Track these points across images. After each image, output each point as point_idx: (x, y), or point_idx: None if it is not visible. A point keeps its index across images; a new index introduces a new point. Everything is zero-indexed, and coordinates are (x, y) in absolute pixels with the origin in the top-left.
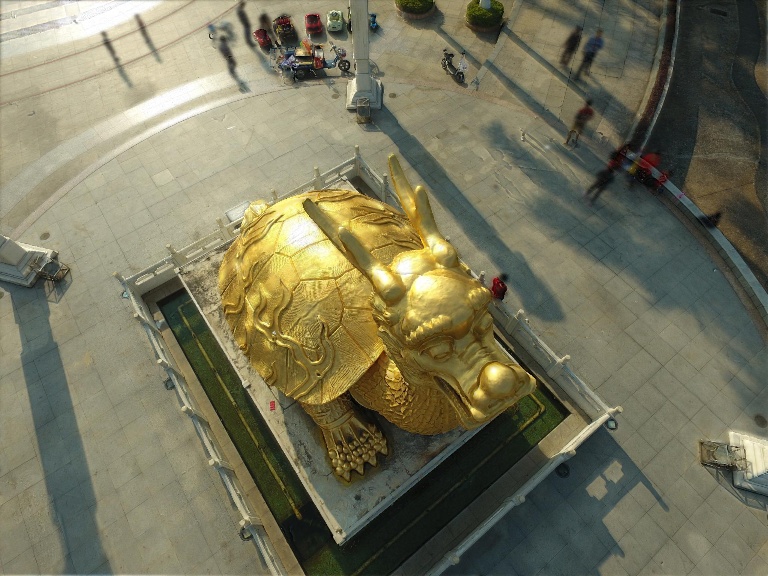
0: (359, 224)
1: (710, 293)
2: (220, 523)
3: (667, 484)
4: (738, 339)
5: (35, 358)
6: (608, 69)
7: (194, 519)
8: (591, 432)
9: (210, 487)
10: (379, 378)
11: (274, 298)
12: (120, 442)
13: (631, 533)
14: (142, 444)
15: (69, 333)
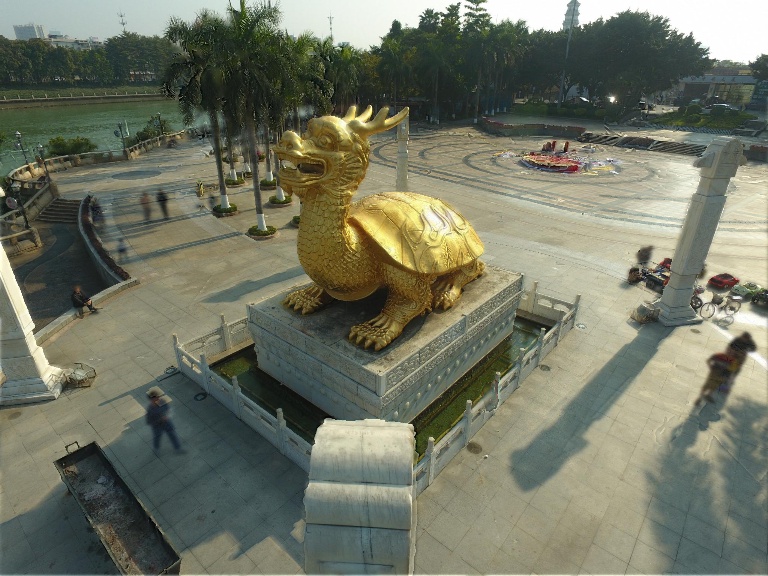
0: (427, 204)
1: None
2: None
3: None
4: None
5: None
6: None
7: None
8: None
9: None
10: None
11: None
12: None
13: (255, 569)
14: None
15: None
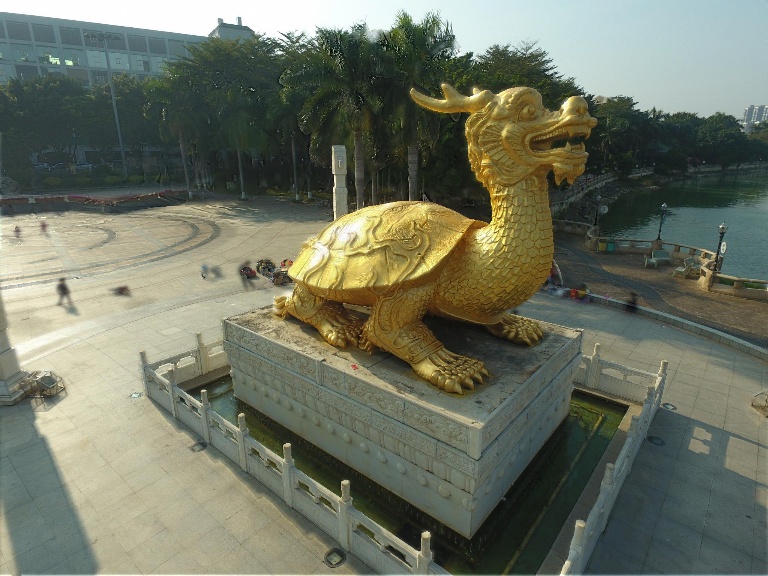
0: None
1: (671, 336)
2: (293, 556)
3: (754, 434)
4: (715, 352)
5: (10, 453)
6: None
7: (253, 559)
8: (656, 387)
9: (269, 524)
10: (471, 248)
11: (364, 228)
12: (132, 505)
13: (760, 472)
14: (165, 502)
15: (61, 429)
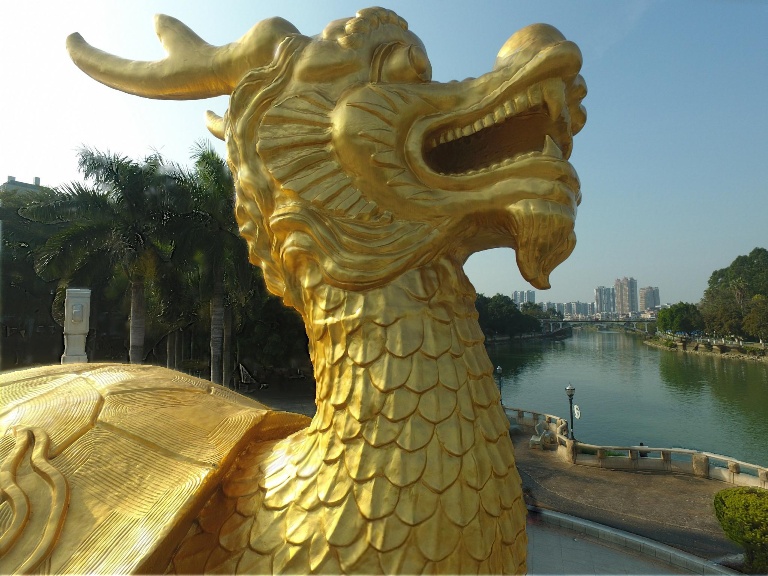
0: None
1: (595, 557)
2: None
3: None
4: None
5: None
6: None
7: None
8: None
9: None
10: (243, 526)
11: None
12: None
13: None
14: None
15: None
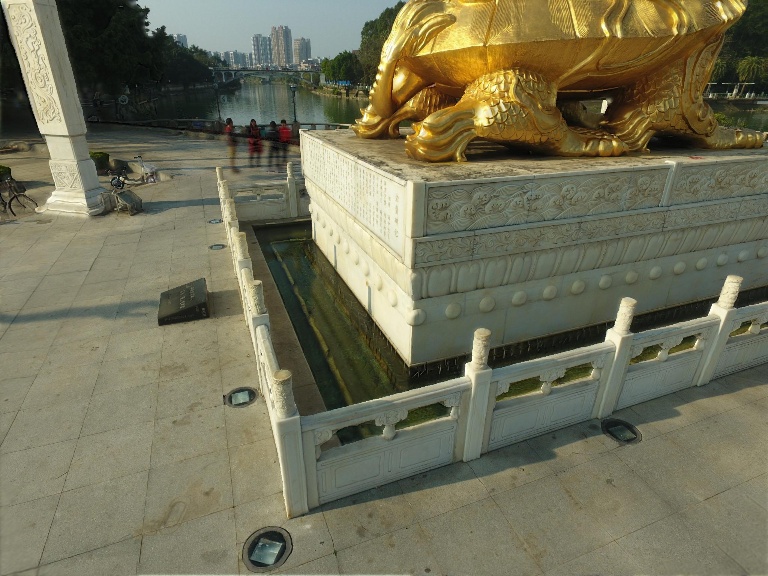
0: None
1: None
2: None
3: None
4: None
5: None
6: (242, 151)
7: None
8: None
9: None
10: None
11: None
12: None
13: None
14: None
15: None
